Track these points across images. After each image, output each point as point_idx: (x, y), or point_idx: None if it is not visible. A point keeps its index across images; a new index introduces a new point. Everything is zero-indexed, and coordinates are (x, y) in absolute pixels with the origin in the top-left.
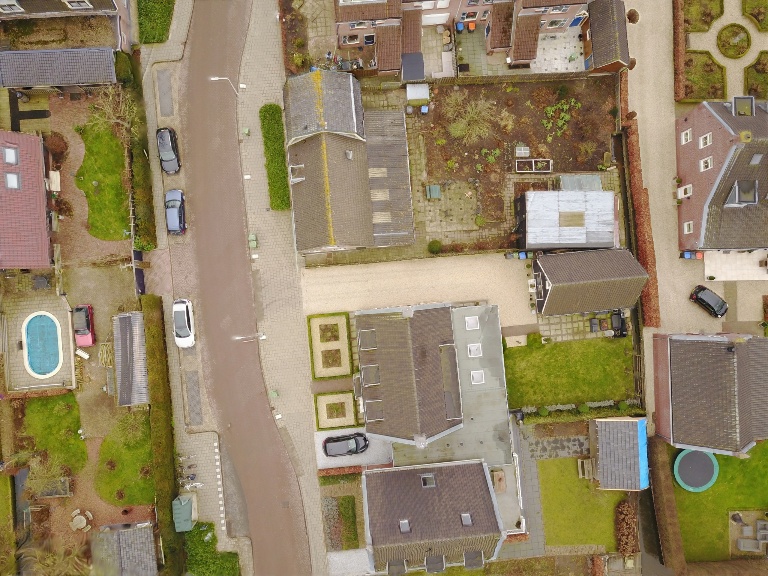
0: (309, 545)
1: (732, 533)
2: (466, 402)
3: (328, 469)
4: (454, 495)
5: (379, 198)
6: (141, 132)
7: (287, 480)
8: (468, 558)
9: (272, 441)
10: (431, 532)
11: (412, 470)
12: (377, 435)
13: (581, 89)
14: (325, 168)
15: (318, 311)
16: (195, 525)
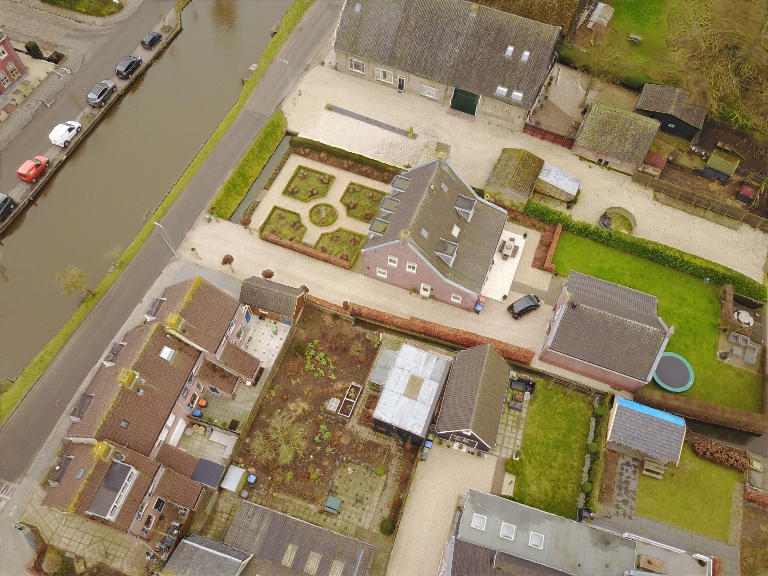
0: None
1: (737, 364)
2: (559, 564)
3: None
4: None
5: (316, 566)
6: None
7: None
8: None
9: None
10: None
11: None
12: None
13: (303, 335)
14: None
15: None
16: None
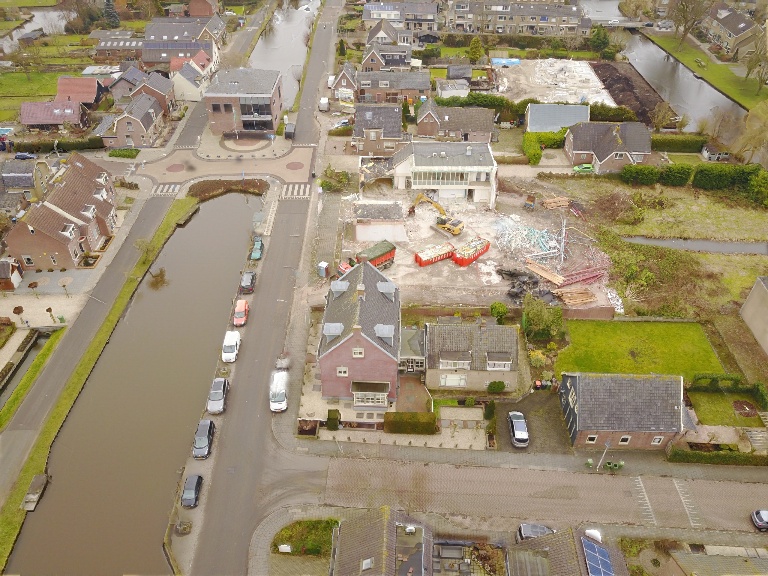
0: None
1: None
2: None
3: None
4: None
5: None
6: (64, 143)
7: None
8: None
9: None
10: None
11: None
12: None
13: None
14: None
15: None
16: None
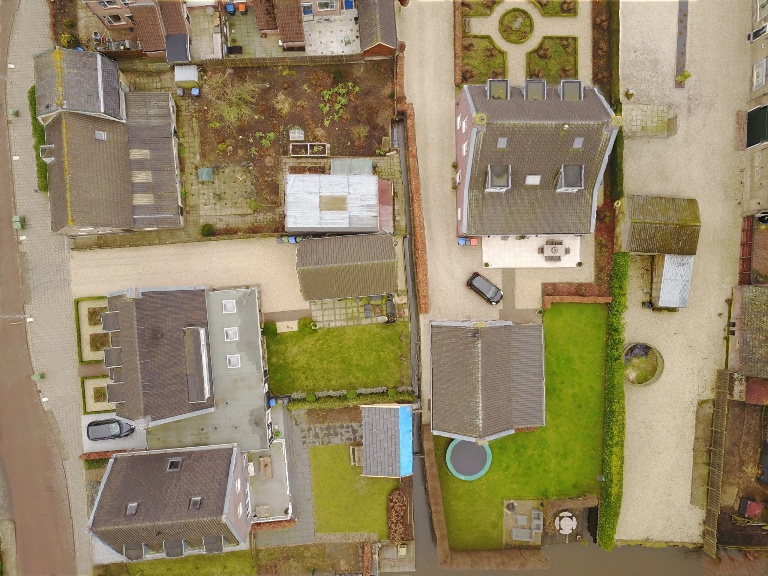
0: (73, 529)
1: (506, 522)
2: (222, 386)
3: (92, 453)
4: (192, 479)
5: (139, 180)
6: None
7: (52, 464)
8: (208, 543)
9: (38, 424)
10: (154, 515)
11: (163, 454)
12: (120, 418)
13: (359, 73)
14: (64, 147)
15: (87, 294)
16: None
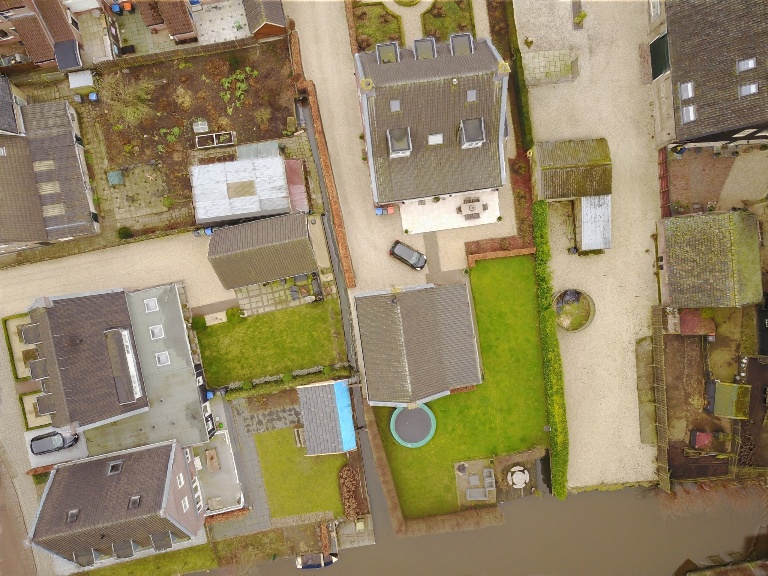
0: None
1: (460, 484)
2: (155, 385)
3: (39, 467)
4: (132, 479)
5: (46, 191)
6: None
7: (2, 483)
8: (156, 540)
9: None
10: (94, 518)
11: (104, 459)
12: (54, 428)
13: (256, 56)
14: None
15: (14, 311)
16: None
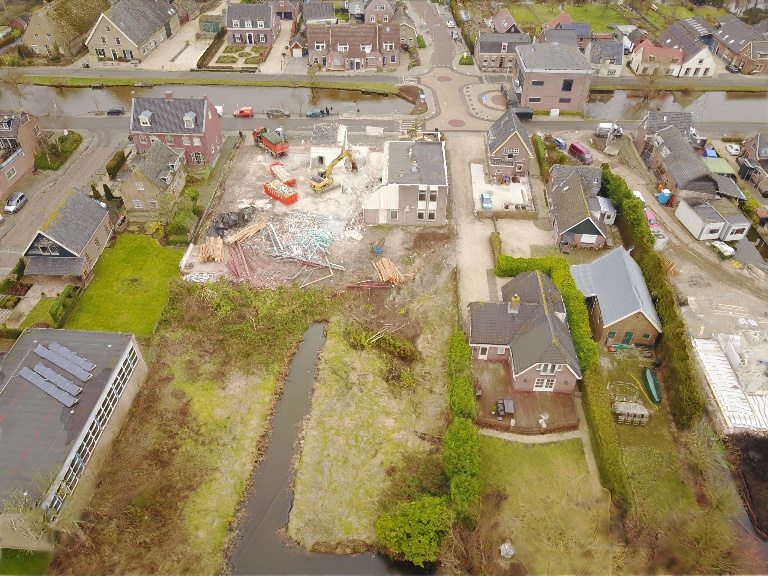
0: (411, 3)
1: None
2: None
3: None
4: None
5: None
6: (467, 37)
7: None
8: None
9: None
10: None
11: None
12: None
13: None
14: None
15: None
16: (444, 3)
